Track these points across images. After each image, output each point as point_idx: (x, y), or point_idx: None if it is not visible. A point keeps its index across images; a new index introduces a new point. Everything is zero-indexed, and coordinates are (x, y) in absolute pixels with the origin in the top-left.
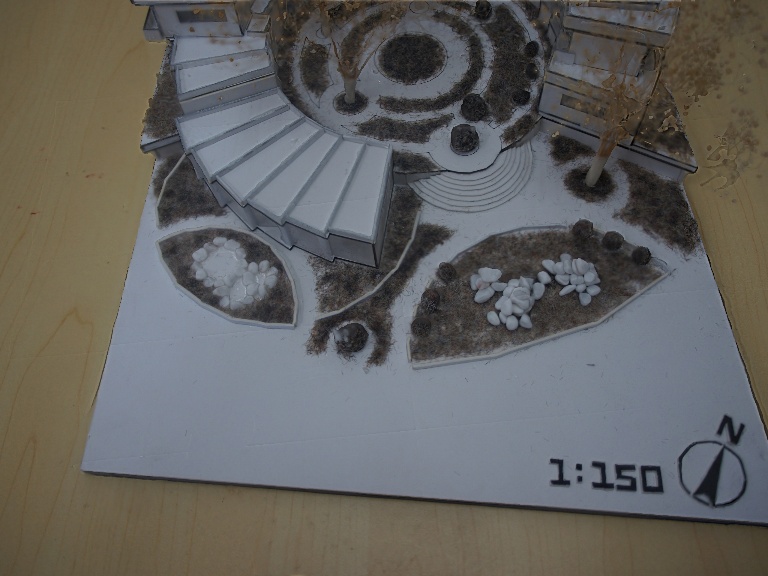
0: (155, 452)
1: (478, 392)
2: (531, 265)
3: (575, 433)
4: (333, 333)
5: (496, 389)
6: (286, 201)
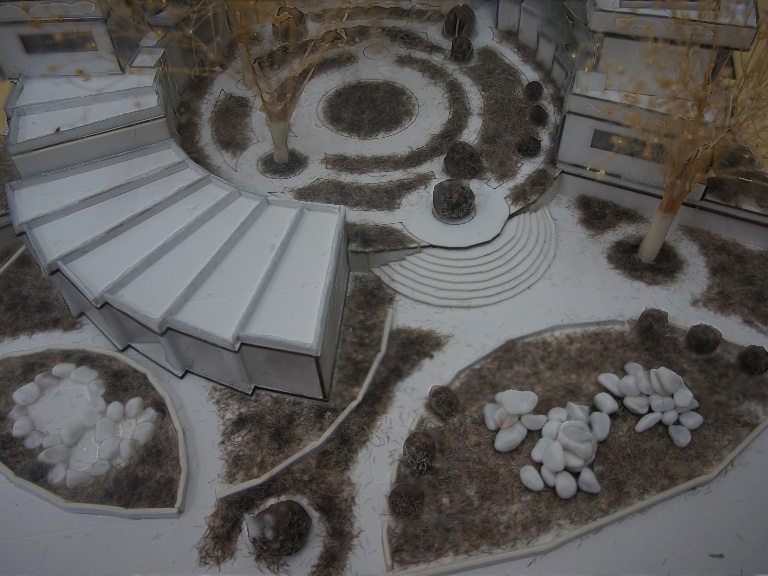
0: None
1: None
2: (580, 384)
3: None
4: (246, 522)
5: None
6: (171, 295)
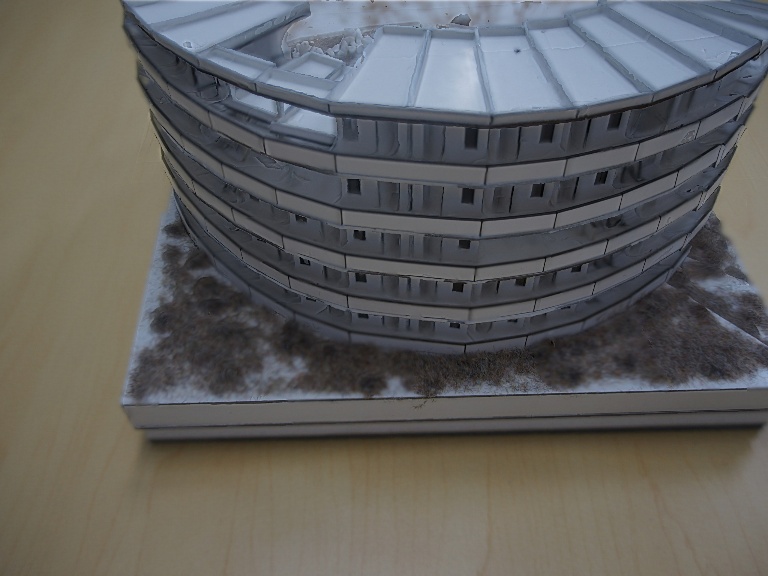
0: (562, 3)
1: (380, 19)
2: None
3: (327, 8)
4: None
5: (369, 20)
6: None
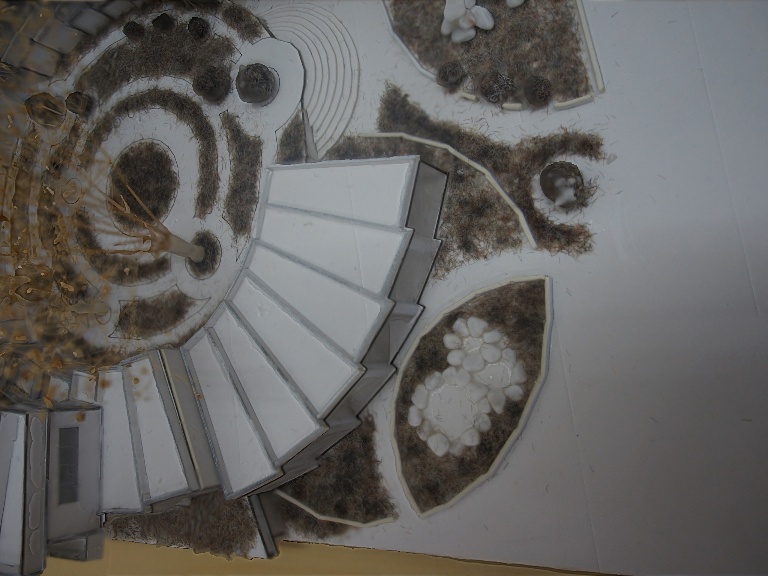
0: None
1: None
2: None
3: None
4: None
5: None
6: (355, 304)
